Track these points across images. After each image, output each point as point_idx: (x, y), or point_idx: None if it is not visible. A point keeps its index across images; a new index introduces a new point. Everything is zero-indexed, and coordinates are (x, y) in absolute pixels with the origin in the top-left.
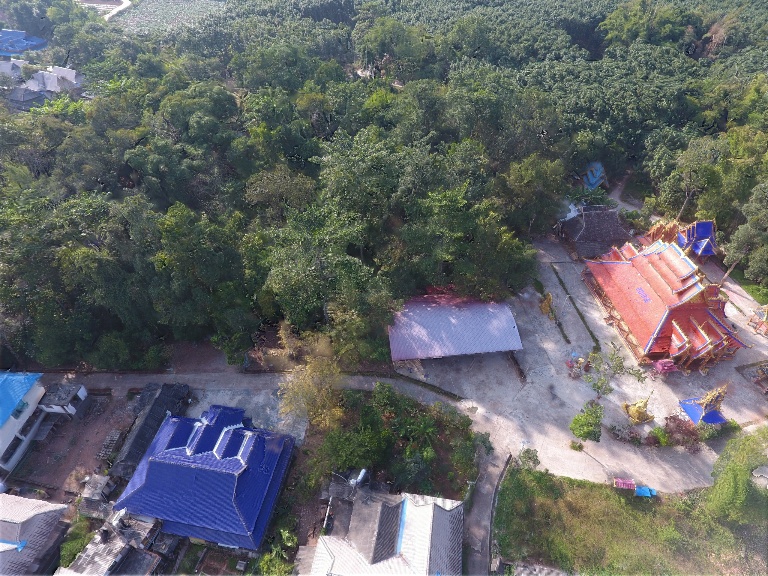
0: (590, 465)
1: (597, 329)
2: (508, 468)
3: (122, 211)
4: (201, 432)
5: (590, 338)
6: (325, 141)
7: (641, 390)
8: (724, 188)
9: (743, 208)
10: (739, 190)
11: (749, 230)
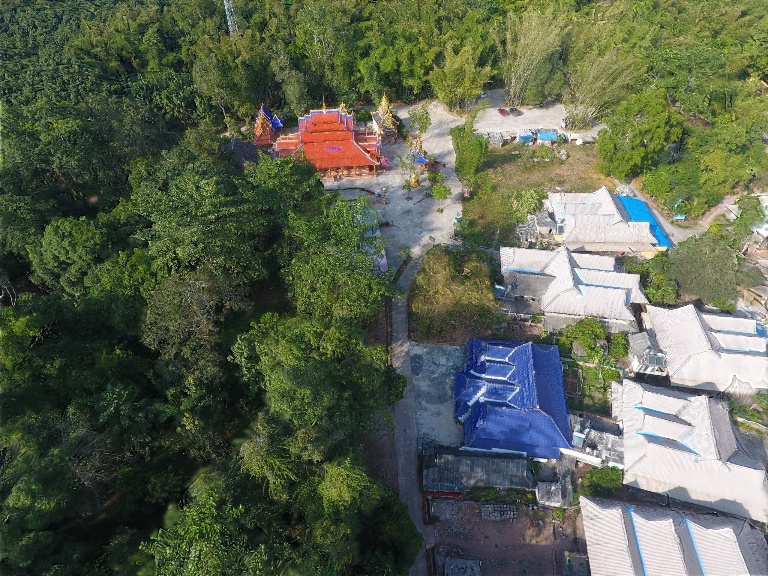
0: (452, 208)
1: (343, 186)
2: (460, 240)
3: (304, 397)
4: (495, 385)
5: (352, 190)
6: (135, 235)
7: (396, 180)
8: (239, 84)
9: (285, 78)
10: (248, 79)
11: (299, 87)
